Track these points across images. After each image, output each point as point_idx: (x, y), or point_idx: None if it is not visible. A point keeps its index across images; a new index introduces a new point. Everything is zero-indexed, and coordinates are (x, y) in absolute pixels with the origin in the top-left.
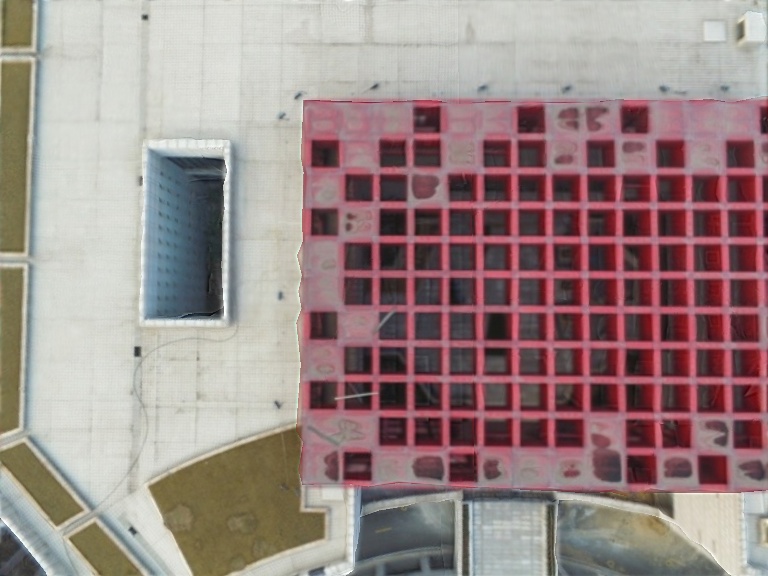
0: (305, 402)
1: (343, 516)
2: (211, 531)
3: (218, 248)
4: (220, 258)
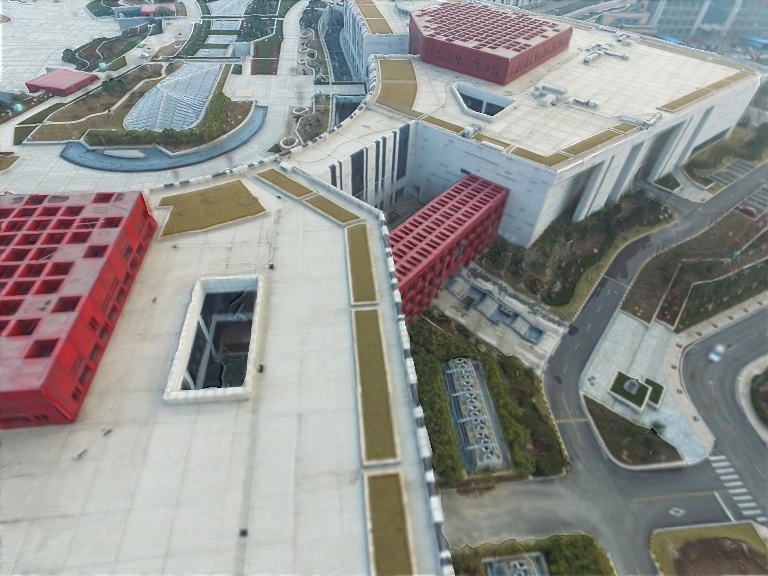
0: (125, 219)
1: (148, 206)
2: (230, 197)
3: (242, 371)
4: (240, 363)
